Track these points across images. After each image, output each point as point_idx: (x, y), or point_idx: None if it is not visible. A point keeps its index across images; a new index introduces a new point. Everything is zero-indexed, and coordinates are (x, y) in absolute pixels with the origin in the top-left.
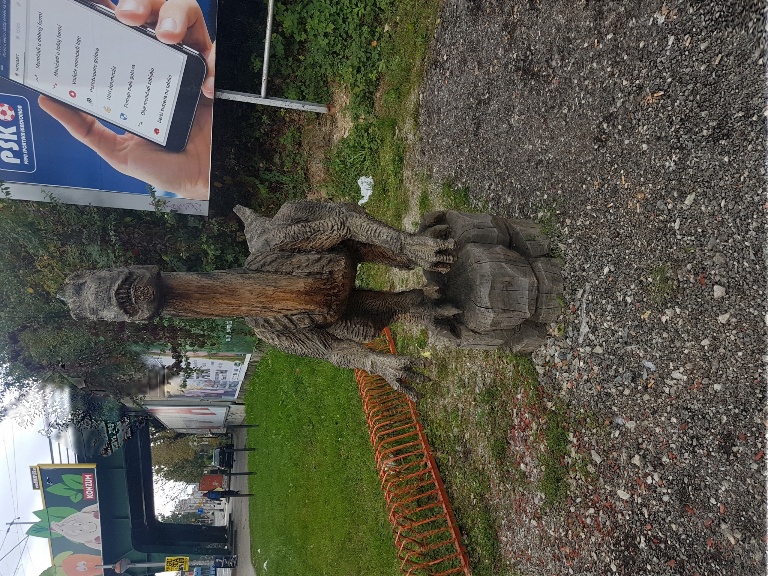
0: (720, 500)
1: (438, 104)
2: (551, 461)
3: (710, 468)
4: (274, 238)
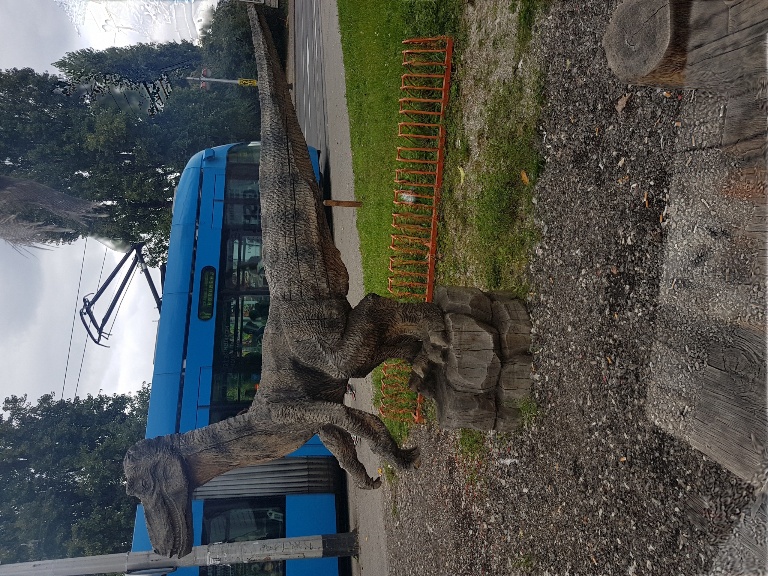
0: None
1: None
2: (466, 438)
3: None
4: (275, 419)
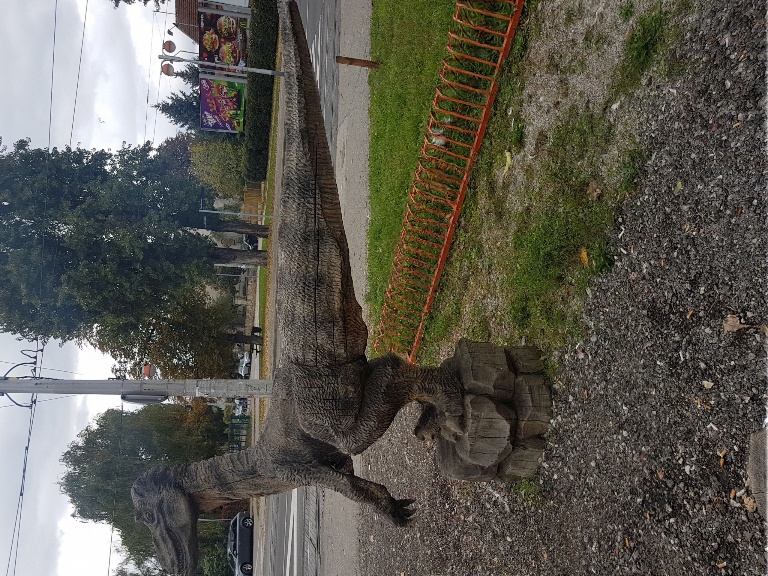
0: (455, 570)
1: (766, 91)
2: None
3: (460, 571)
4: None
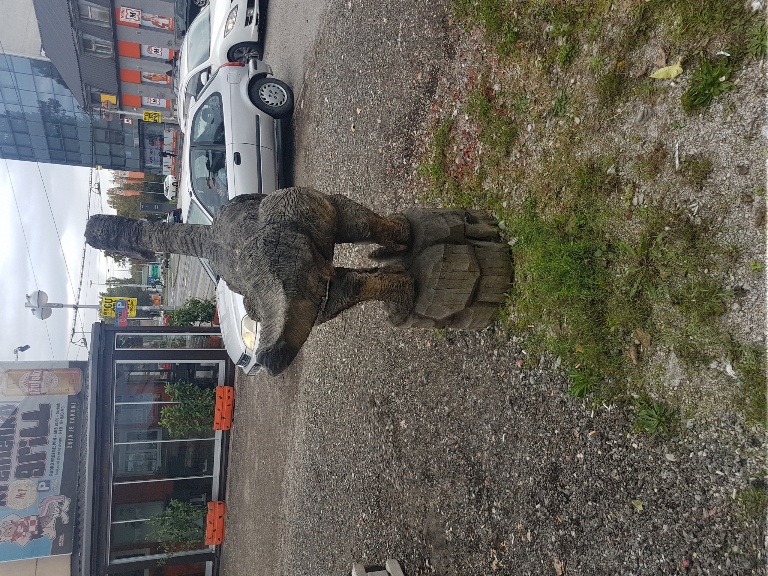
0: None
1: None
2: None
3: None
4: None
